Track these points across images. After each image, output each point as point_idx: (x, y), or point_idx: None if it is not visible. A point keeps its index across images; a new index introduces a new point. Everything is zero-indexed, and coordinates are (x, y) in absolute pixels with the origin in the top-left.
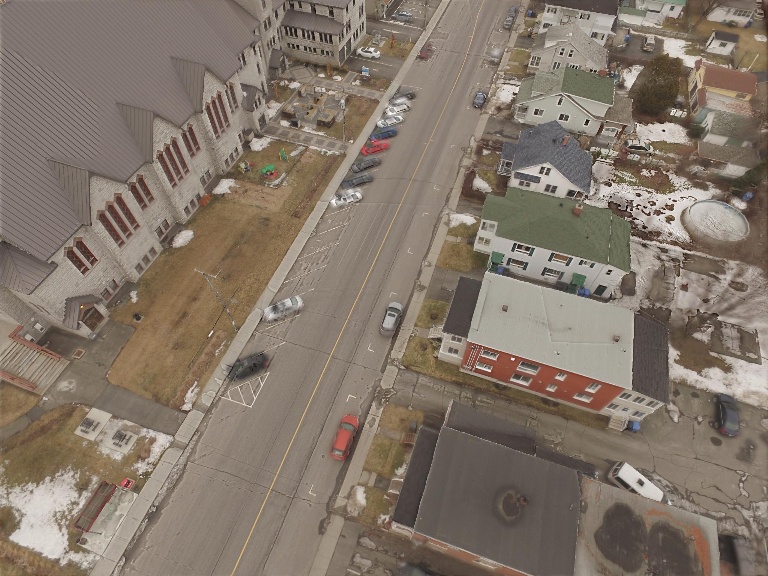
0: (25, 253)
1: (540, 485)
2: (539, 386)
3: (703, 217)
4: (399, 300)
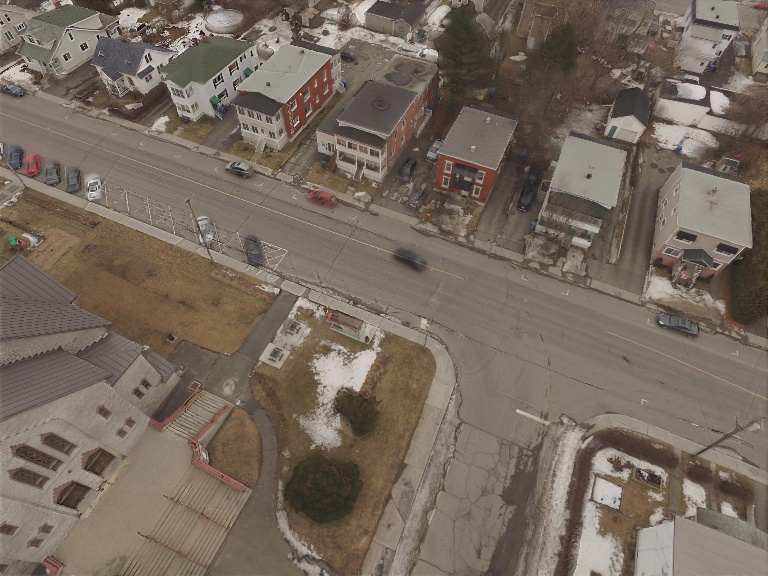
0: (88, 349)
1: (373, 94)
2: (314, 105)
3: (219, 23)
4: (223, 167)
